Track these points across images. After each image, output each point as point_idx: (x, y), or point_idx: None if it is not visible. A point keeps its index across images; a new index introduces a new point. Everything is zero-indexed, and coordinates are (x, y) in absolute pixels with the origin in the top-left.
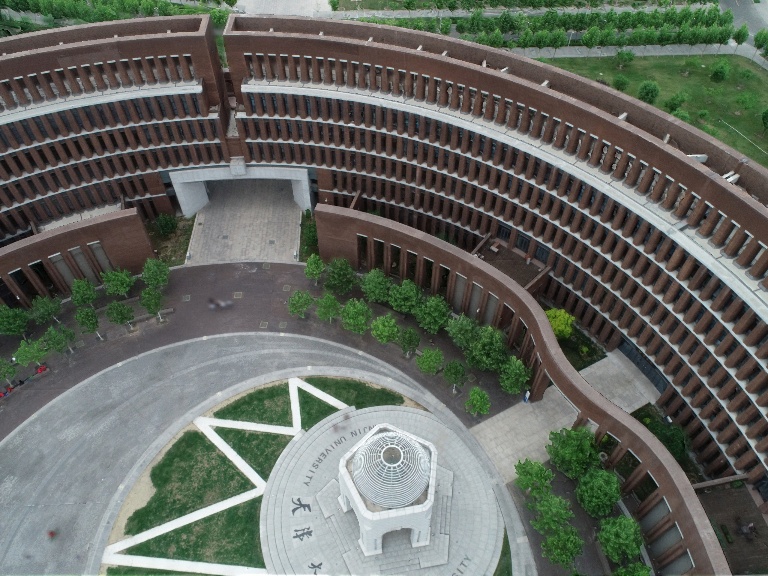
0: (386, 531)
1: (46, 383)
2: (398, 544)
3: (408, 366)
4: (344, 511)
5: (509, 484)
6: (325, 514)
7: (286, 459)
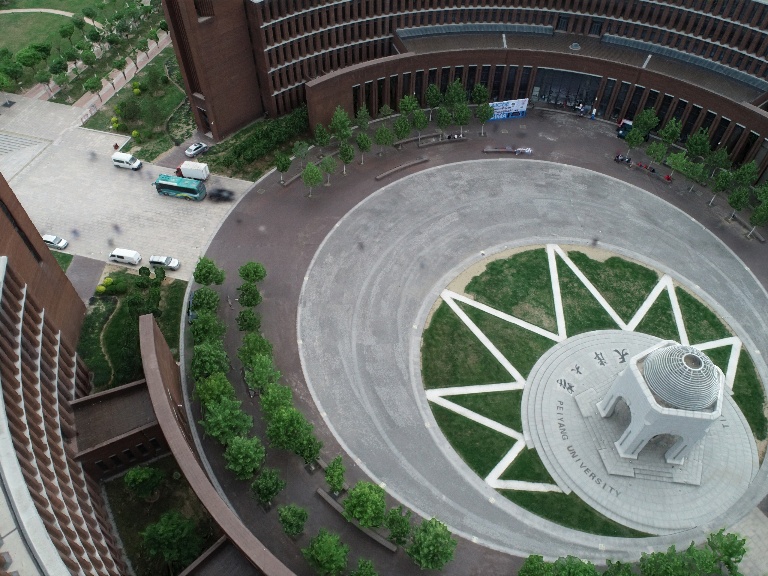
0: (623, 395)
1: (658, 184)
2: (613, 431)
3: None
4: None
5: (709, 546)
6: None
7: None
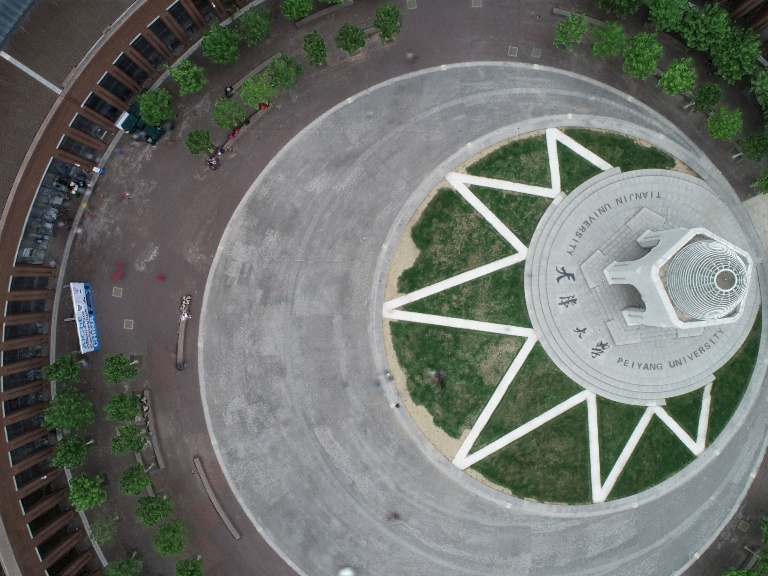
0: None
1: (273, 122)
2: None
3: (685, 120)
4: (610, 284)
5: None
6: (590, 285)
7: (547, 225)
